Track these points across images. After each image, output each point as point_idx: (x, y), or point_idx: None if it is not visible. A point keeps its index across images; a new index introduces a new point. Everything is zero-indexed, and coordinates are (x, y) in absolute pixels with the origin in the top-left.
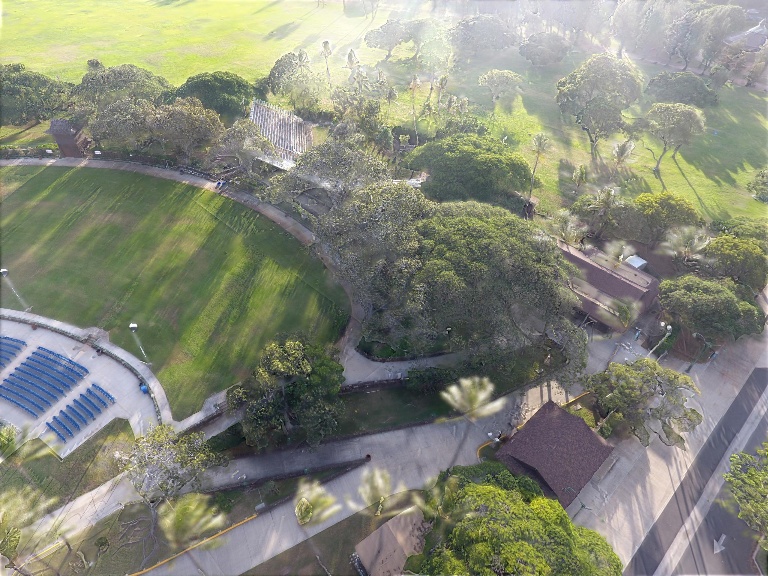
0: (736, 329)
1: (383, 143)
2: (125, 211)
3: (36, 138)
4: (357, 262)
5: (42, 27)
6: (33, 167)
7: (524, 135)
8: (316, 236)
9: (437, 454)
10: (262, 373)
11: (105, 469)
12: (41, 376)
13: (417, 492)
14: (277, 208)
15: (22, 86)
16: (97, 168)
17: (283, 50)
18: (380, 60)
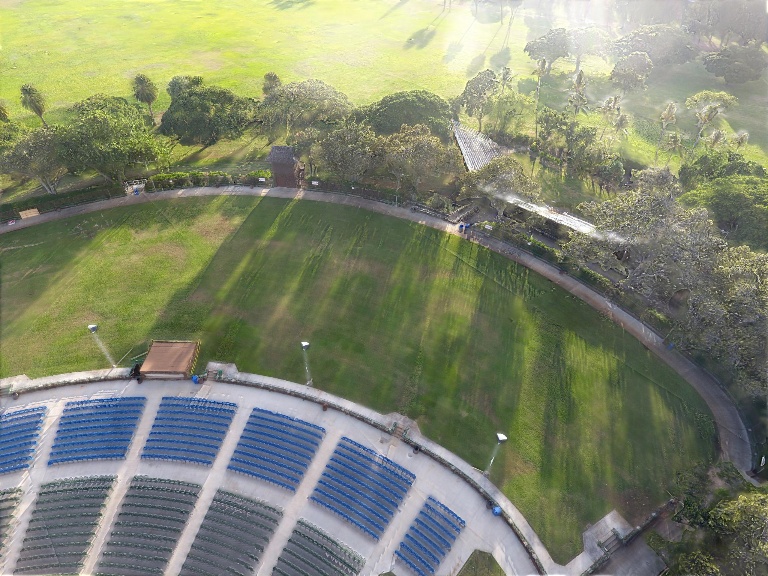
0: None
1: (613, 178)
2: (369, 257)
3: (219, 158)
4: None
5: (176, 31)
6: (248, 198)
7: None
8: (611, 303)
9: None
10: None
11: None
12: (361, 479)
13: None
14: (544, 262)
15: (211, 102)
16: (317, 201)
17: (431, 60)
18: None
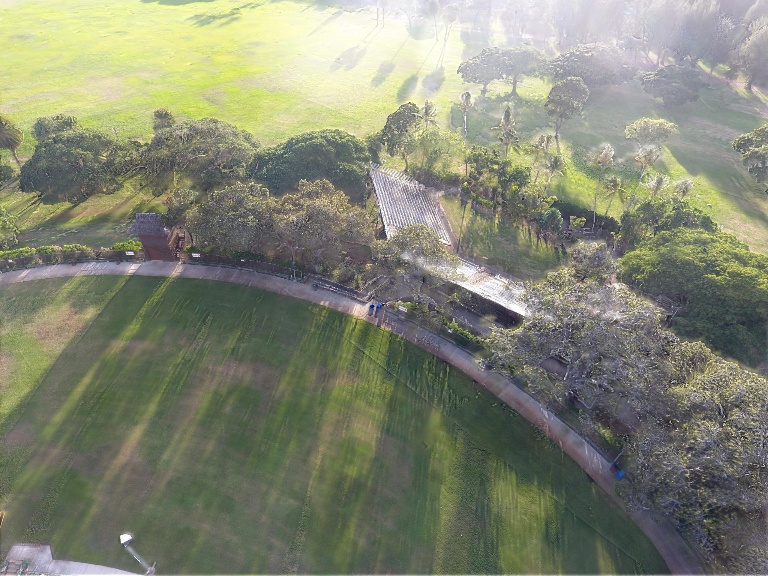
0: None
1: (550, 227)
2: (254, 359)
3: (96, 215)
4: None
5: (75, 53)
6: (111, 278)
7: (703, 206)
8: (547, 410)
9: None
10: None
11: None
12: None
13: None
14: (469, 353)
15: (80, 150)
16: (198, 279)
17: (359, 83)
18: (477, 96)
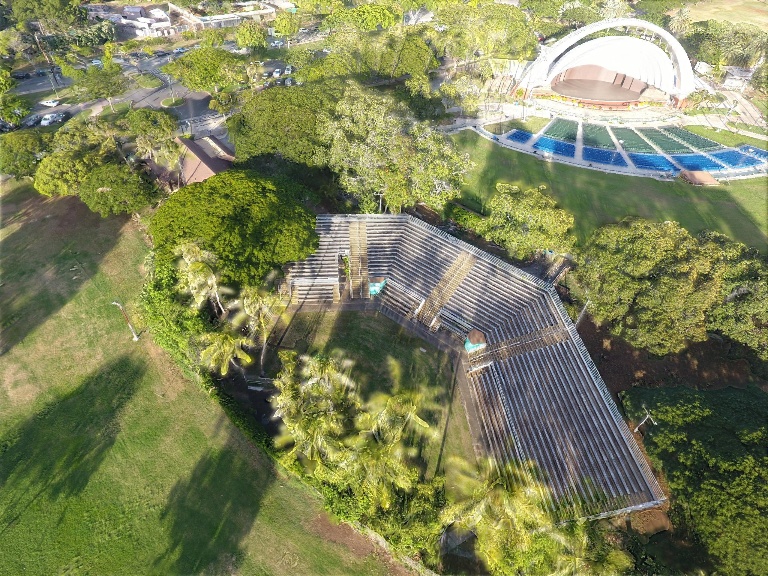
0: None
1: None
2: None
3: None
4: None
5: None
6: None
7: None
8: None
9: None
10: None
11: (493, 126)
12: None
13: None
14: None
15: None
16: None
17: None
18: None
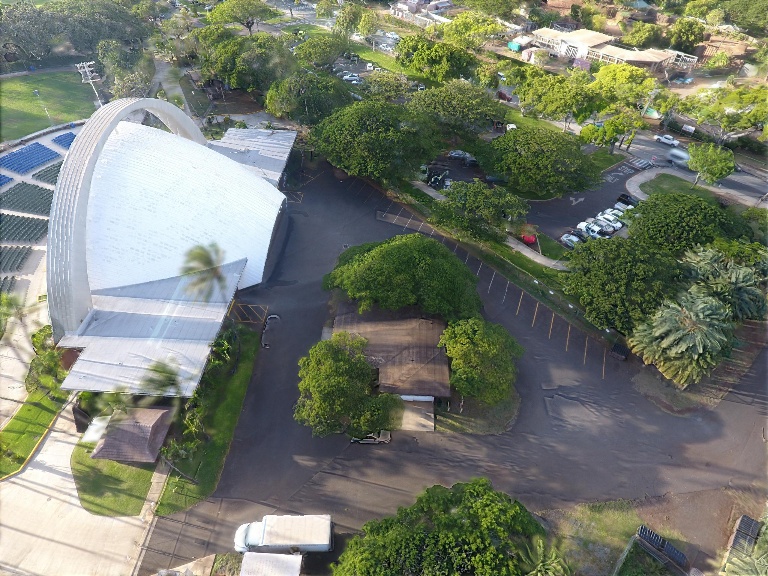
0: (165, 8)
1: None
2: None
3: None
4: (64, 23)
5: None
6: None
7: None
8: None
9: (169, 74)
10: (114, 45)
11: None
12: None
13: (181, 78)
14: None
15: None
16: None
17: None
18: None
